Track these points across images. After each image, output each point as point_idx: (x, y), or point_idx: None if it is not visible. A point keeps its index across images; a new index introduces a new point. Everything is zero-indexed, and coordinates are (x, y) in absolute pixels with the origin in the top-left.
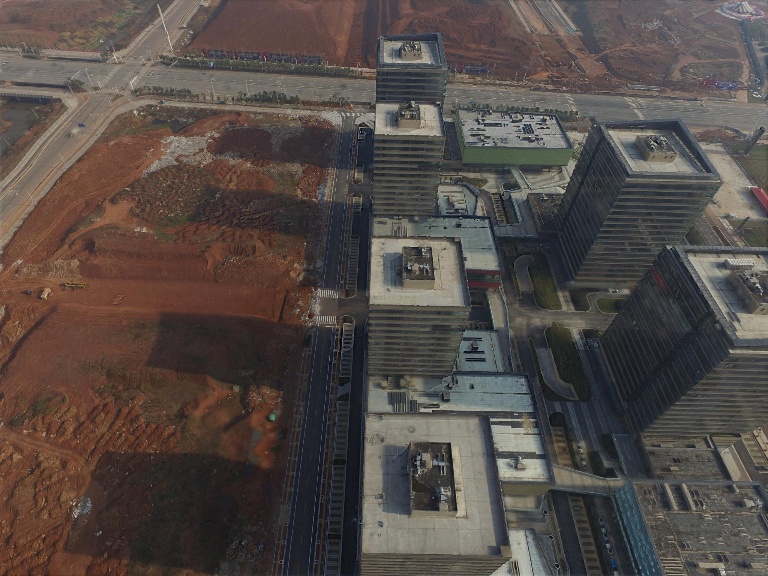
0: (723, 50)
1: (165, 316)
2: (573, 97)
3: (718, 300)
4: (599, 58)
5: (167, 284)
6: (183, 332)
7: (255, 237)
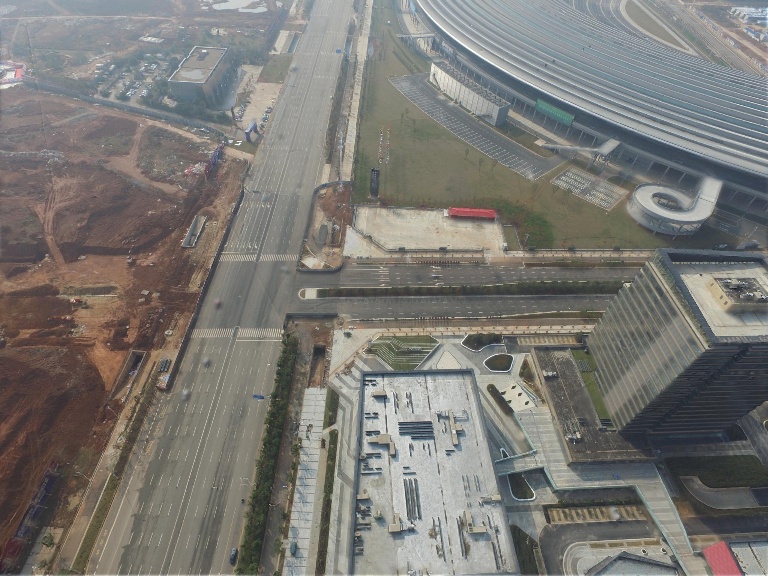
0: (108, 126)
1: None
2: (210, 327)
3: None
4: (64, 256)
5: None
6: None
7: None
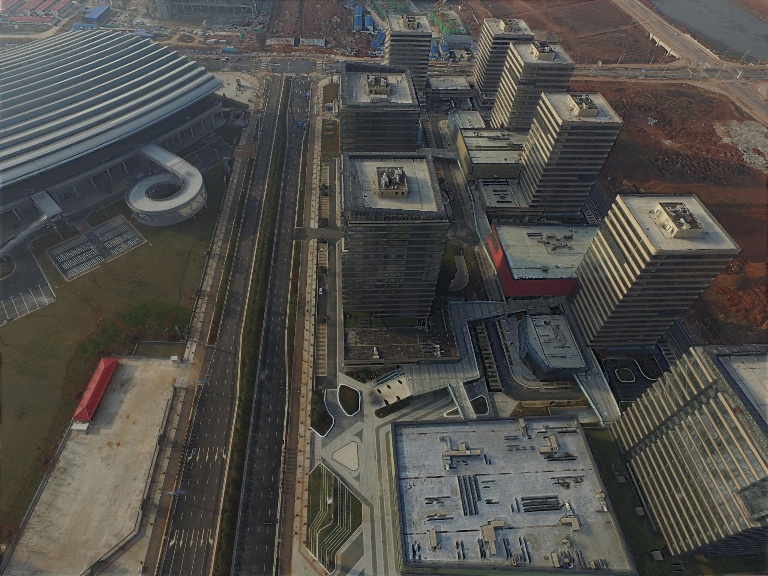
0: None
1: (733, 216)
2: None
3: (402, 87)
4: None
5: (766, 252)
6: (707, 203)
7: (741, 293)
